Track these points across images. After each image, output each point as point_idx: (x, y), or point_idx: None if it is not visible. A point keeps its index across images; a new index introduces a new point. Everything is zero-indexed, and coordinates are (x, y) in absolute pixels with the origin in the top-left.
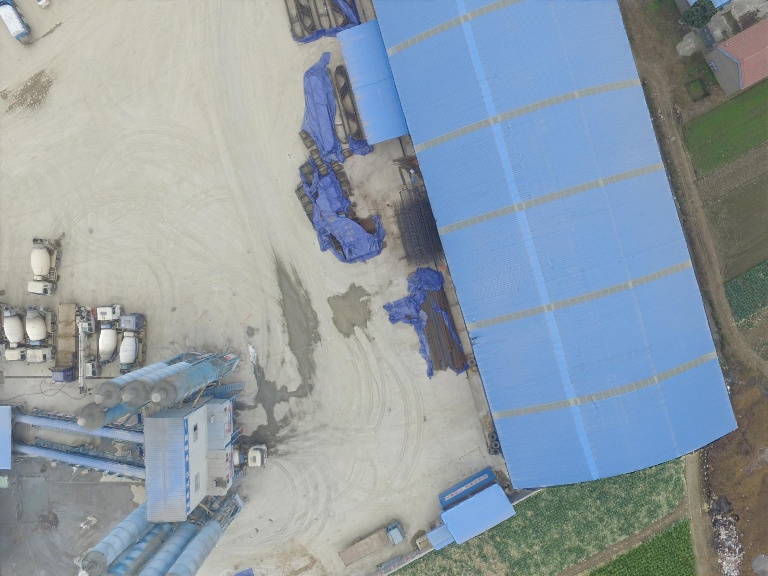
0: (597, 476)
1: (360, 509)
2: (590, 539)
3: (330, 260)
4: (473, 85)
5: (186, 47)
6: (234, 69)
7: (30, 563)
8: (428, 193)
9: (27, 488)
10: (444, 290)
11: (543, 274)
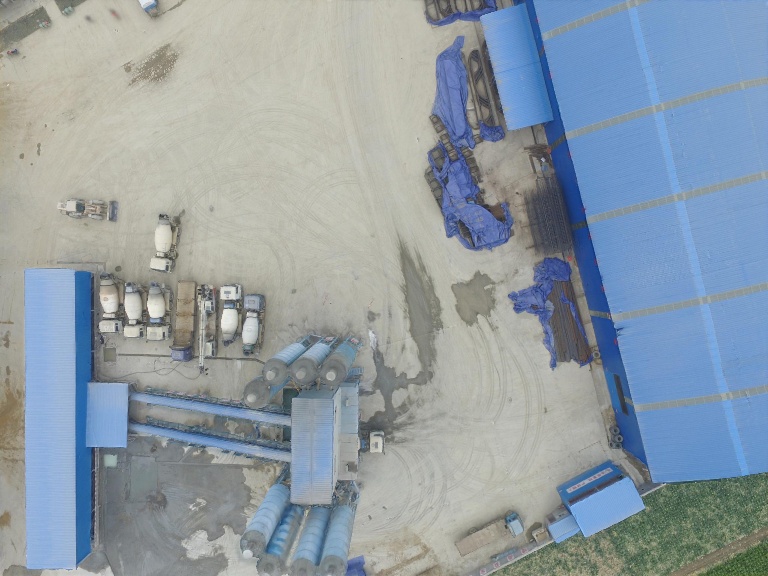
0: (746, 472)
1: (476, 499)
2: (708, 537)
3: (456, 247)
4: (636, 72)
5: (317, 26)
6: (365, 50)
7: (136, 543)
8: (578, 181)
9: (136, 467)
10: (571, 281)
11: (700, 266)
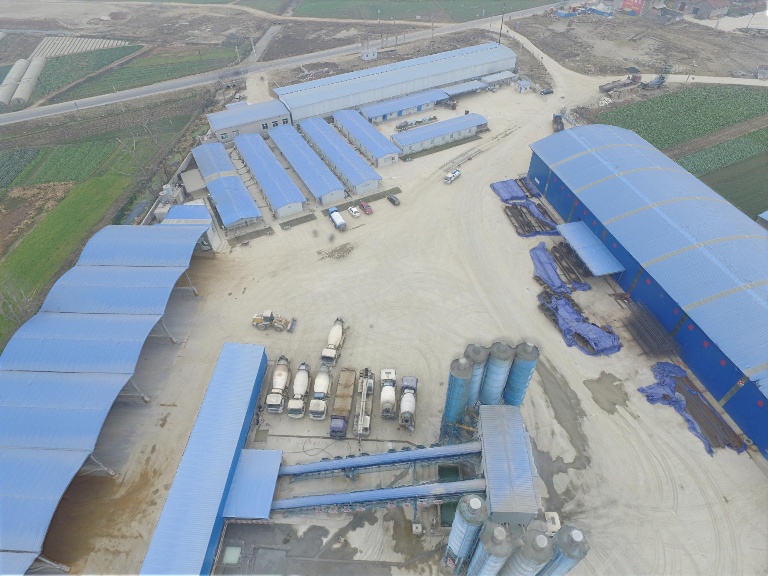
0: None
1: None
2: None
3: (577, 353)
4: (673, 231)
5: (447, 236)
6: (480, 247)
7: None
8: (663, 288)
9: (260, 565)
10: (689, 379)
11: None
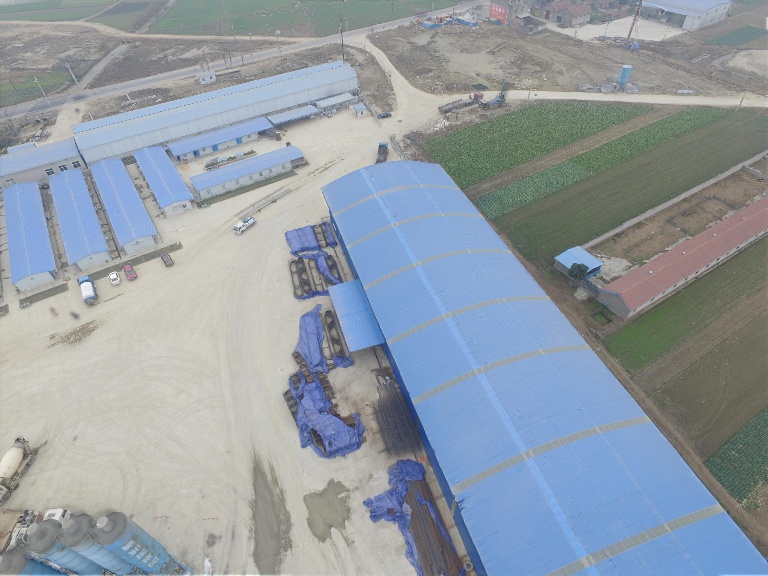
0: None
1: None
2: None
3: (310, 456)
4: (427, 297)
5: (213, 304)
6: (247, 316)
7: None
8: (400, 372)
9: None
10: (426, 481)
11: (513, 423)
